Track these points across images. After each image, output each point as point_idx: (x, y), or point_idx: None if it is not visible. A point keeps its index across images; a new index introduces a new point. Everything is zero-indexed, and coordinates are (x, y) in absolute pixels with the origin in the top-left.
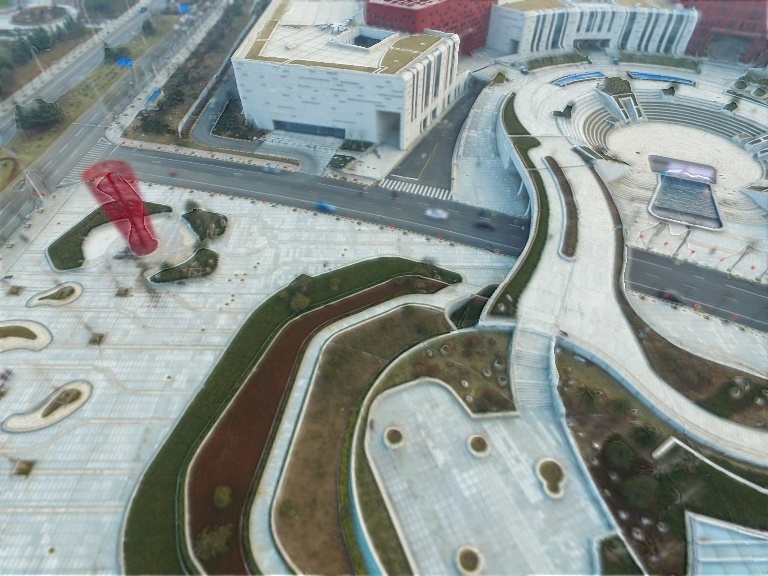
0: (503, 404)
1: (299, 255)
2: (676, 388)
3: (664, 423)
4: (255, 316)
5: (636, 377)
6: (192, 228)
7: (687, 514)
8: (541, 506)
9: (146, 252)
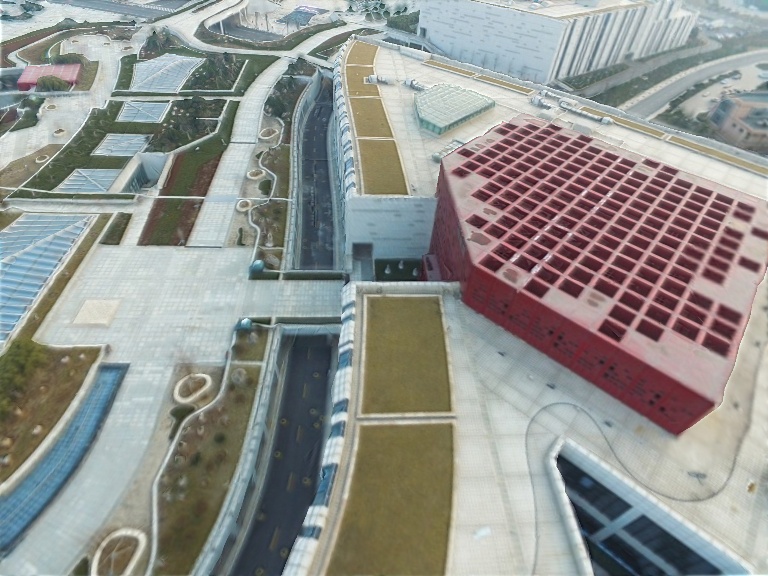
0: (124, 38)
1: (76, 19)
2: (198, 38)
3: (185, 44)
4: (42, 29)
5: (185, 36)
6: (24, 8)
7: None
8: None
9: None
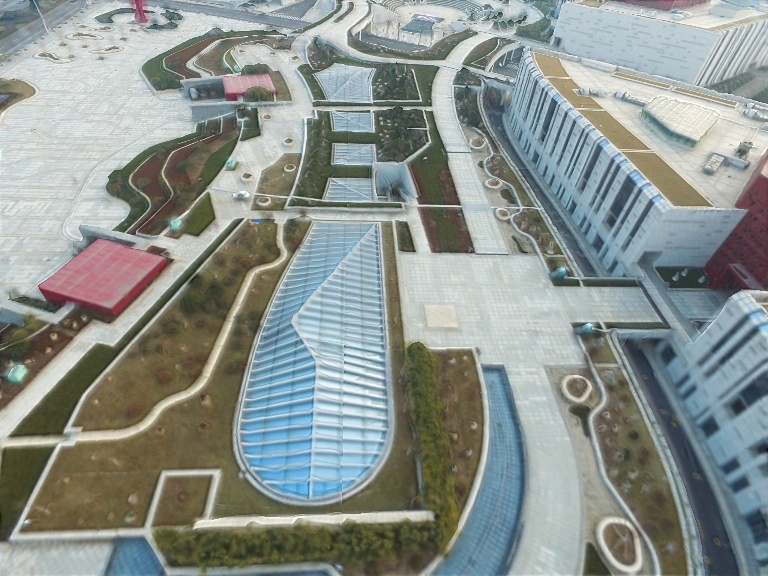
0: (286, 48)
1: None
2: (354, 48)
3: (344, 54)
4: (194, 38)
5: None
6: (165, 17)
7: (335, 63)
8: (288, 62)
9: (143, 22)
